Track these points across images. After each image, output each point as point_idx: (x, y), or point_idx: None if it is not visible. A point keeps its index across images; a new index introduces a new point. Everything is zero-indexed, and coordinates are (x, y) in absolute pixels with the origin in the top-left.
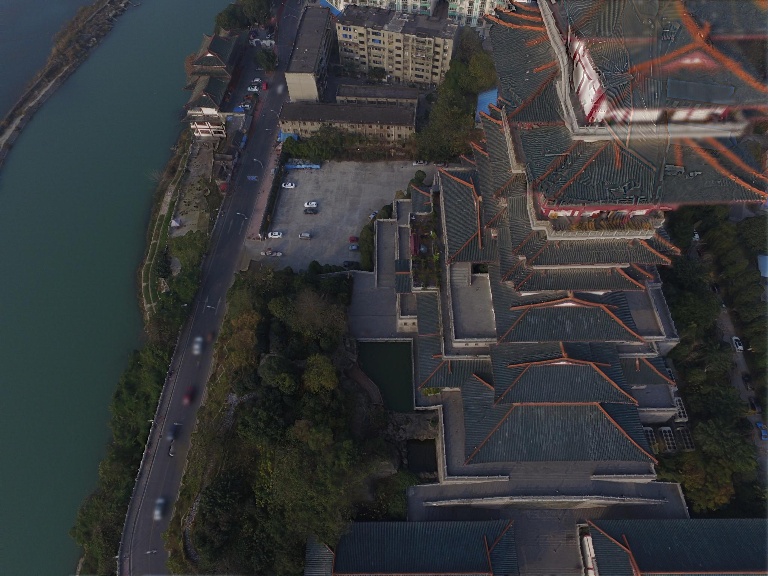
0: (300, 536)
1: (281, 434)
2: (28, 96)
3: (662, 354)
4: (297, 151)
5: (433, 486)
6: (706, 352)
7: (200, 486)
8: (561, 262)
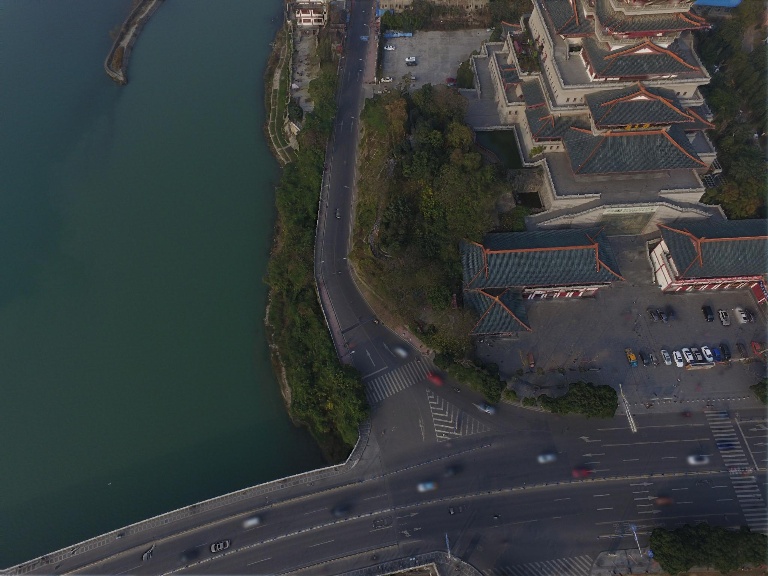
0: (458, 234)
1: (436, 171)
2: (137, 11)
3: None
4: (393, 23)
5: (542, 215)
6: (732, 127)
7: (376, 215)
8: None
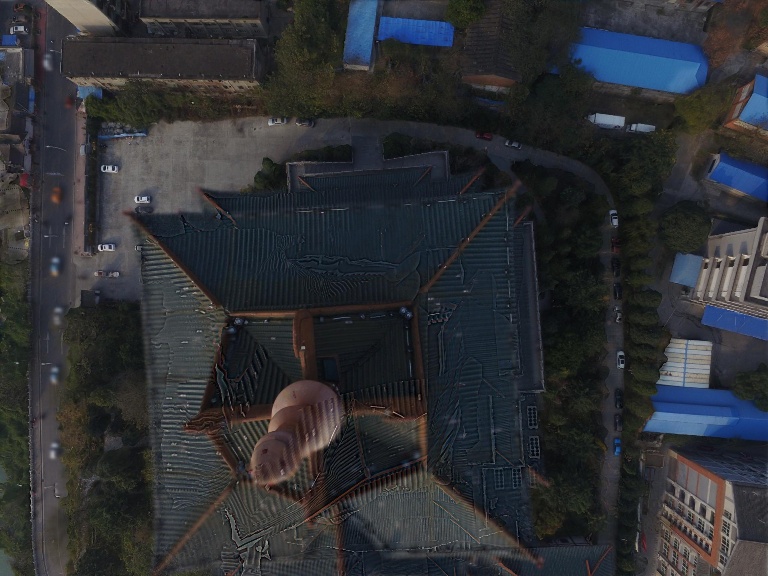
0: None
1: (133, 522)
2: None
3: None
4: (108, 114)
5: None
6: (574, 393)
7: (79, 547)
8: None
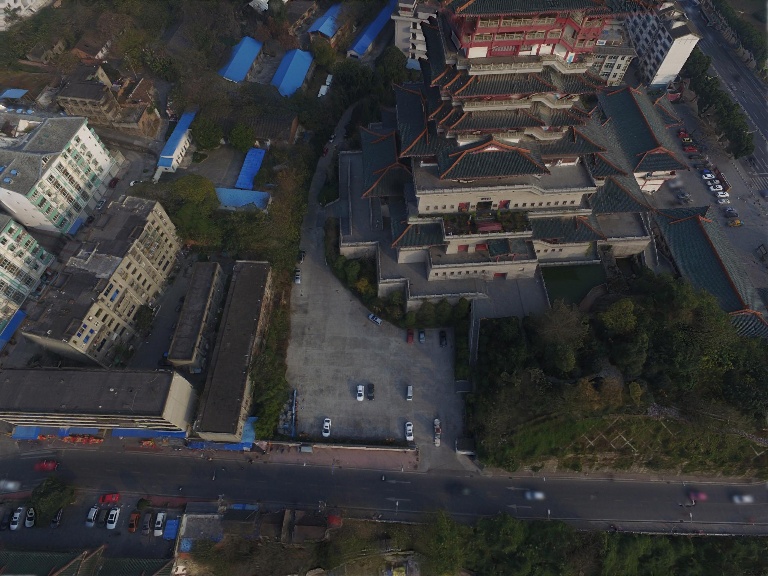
0: None
1: None
2: None
3: None
4: None
5: None
6: None
7: None
8: None
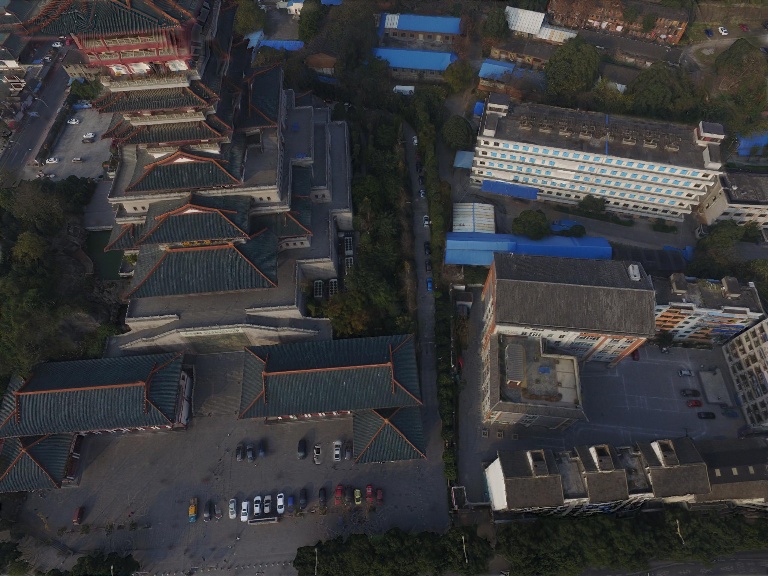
0: None
1: None
2: None
3: (350, 228)
4: (84, 92)
5: (130, 334)
6: None
7: None
8: (127, 109)
